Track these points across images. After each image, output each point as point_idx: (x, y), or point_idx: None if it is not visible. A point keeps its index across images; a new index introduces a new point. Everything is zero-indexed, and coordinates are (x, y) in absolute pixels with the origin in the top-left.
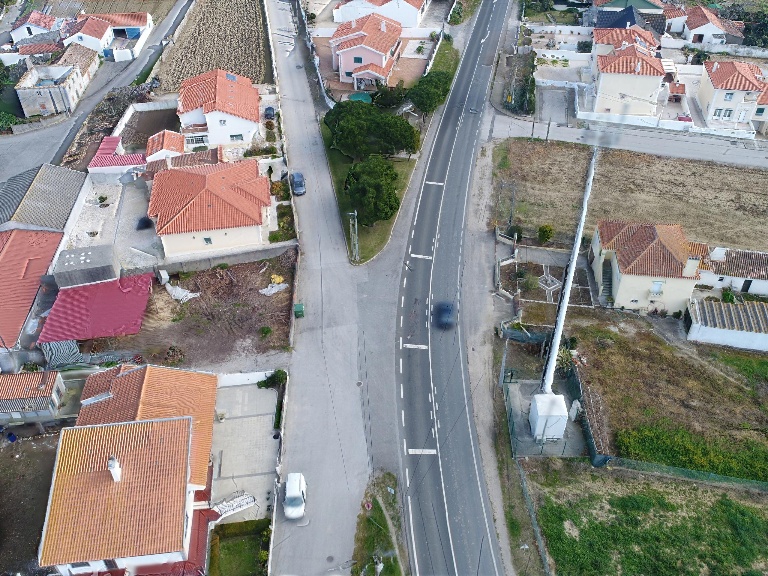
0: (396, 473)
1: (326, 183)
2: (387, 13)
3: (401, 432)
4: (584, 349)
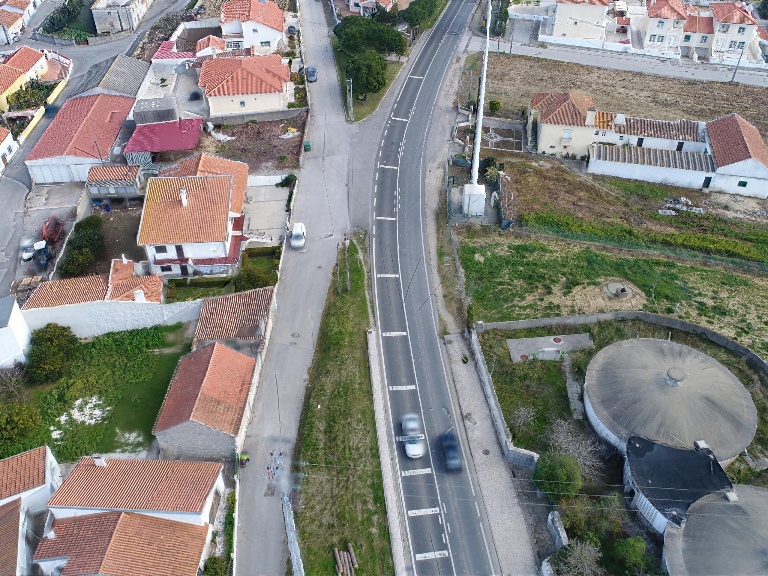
0: (367, 228)
1: (333, 75)
2: None
3: (373, 208)
4: (510, 173)
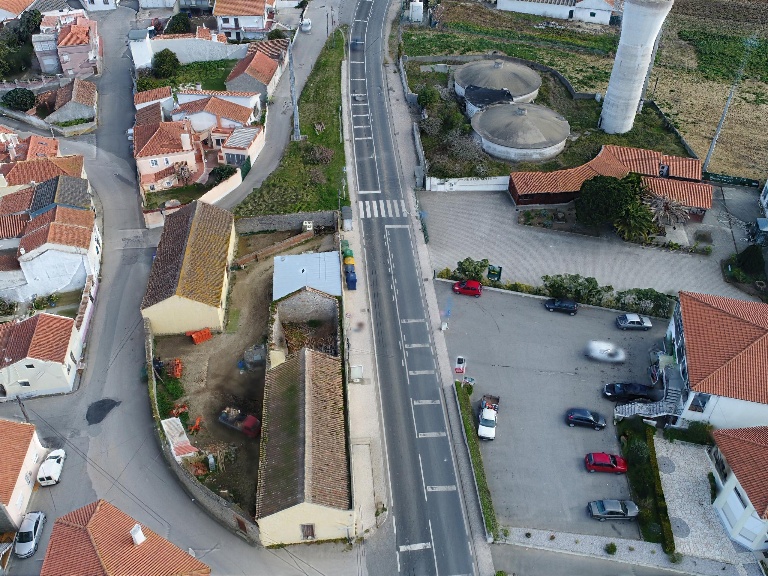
0: None
1: None
2: None
3: (354, 16)
4: (445, 6)
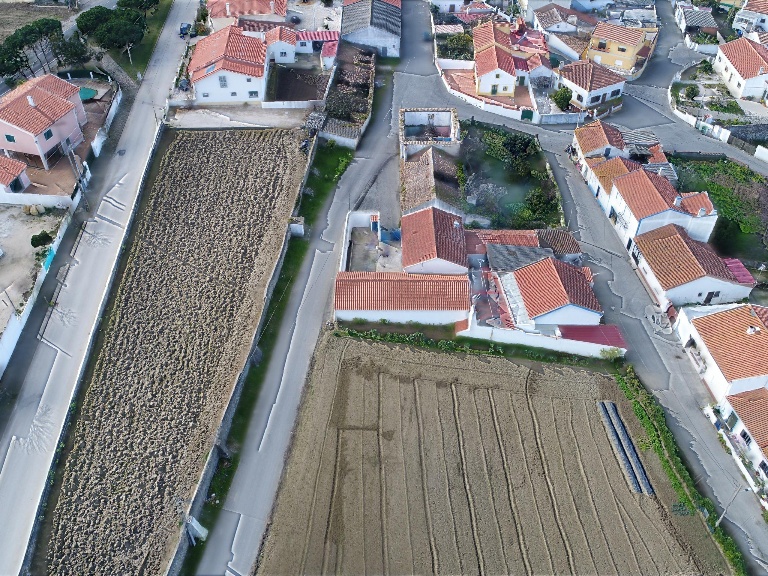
0: None
1: None
2: None
3: None
4: None
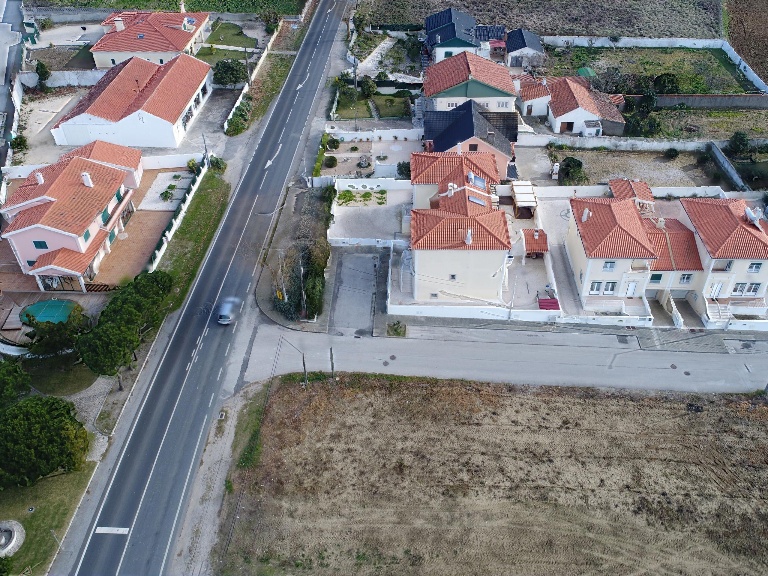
0: None
1: None
2: (129, 130)
3: None
4: None
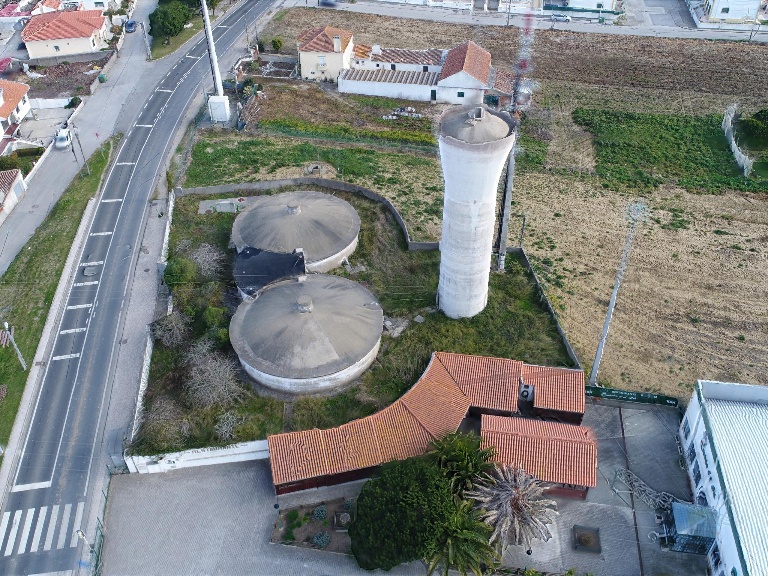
0: (125, 132)
1: None
2: None
3: (136, 119)
4: (269, 93)
